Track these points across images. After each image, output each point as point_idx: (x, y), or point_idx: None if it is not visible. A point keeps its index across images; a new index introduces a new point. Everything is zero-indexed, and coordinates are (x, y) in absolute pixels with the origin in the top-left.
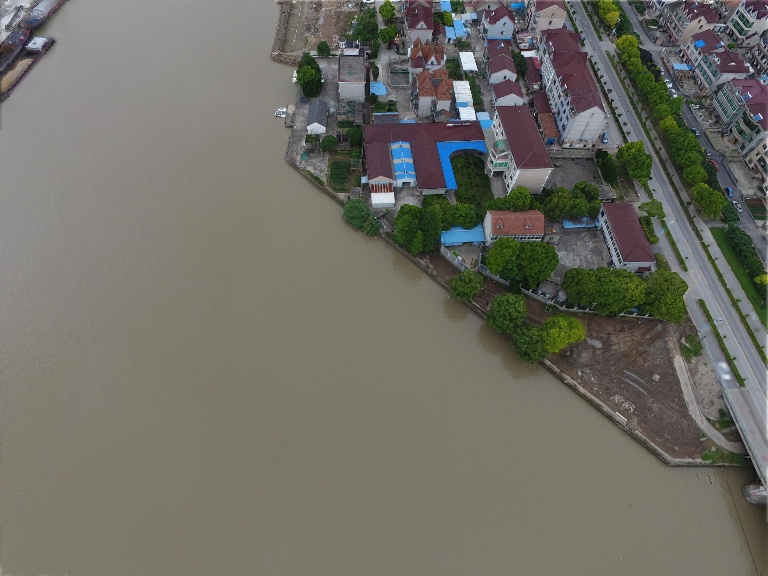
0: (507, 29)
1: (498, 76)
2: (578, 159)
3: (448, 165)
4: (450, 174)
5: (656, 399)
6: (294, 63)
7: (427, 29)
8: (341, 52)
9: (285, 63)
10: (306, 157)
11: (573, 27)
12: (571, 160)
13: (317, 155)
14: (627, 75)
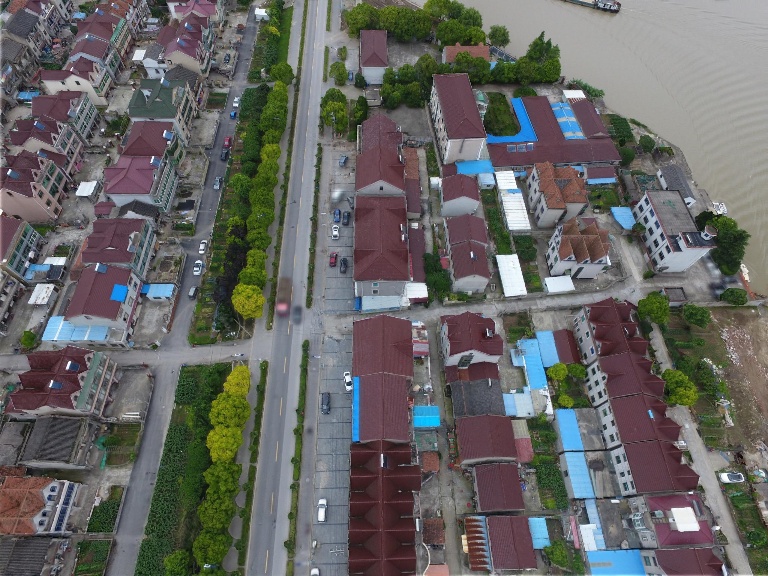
0: None
1: None
2: None
3: (522, 119)
4: (519, 111)
5: (379, 2)
6: (761, 295)
7: None
8: None
9: None
10: None
11: (306, 404)
12: None
13: None
14: None
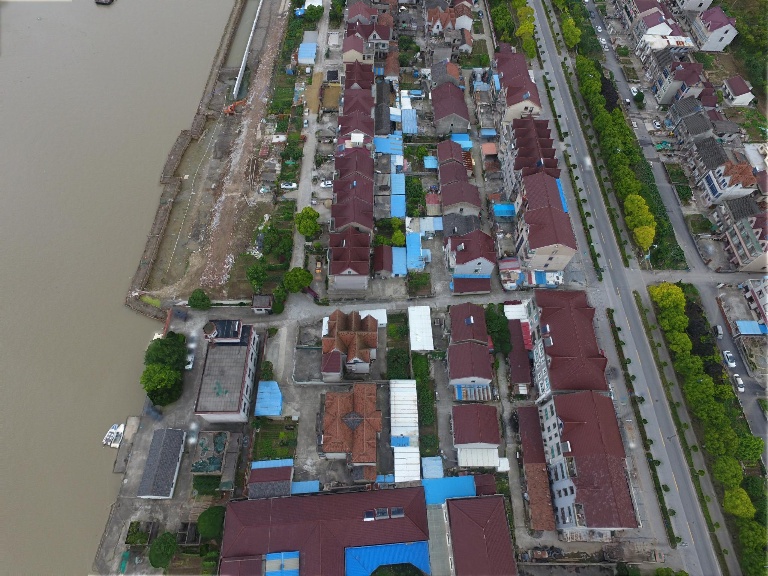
0: (484, 267)
1: (462, 380)
2: (586, 568)
3: None
4: None
5: None
6: (157, 317)
7: (358, 275)
8: (211, 340)
9: (144, 315)
10: (127, 565)
11: (586, 237)
12: (574, 571)
13: (147, 559)
14: (667, 347)
